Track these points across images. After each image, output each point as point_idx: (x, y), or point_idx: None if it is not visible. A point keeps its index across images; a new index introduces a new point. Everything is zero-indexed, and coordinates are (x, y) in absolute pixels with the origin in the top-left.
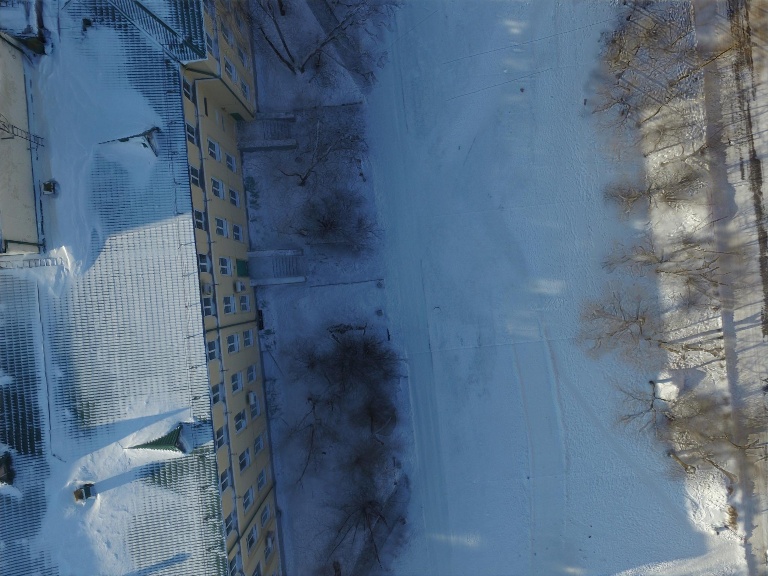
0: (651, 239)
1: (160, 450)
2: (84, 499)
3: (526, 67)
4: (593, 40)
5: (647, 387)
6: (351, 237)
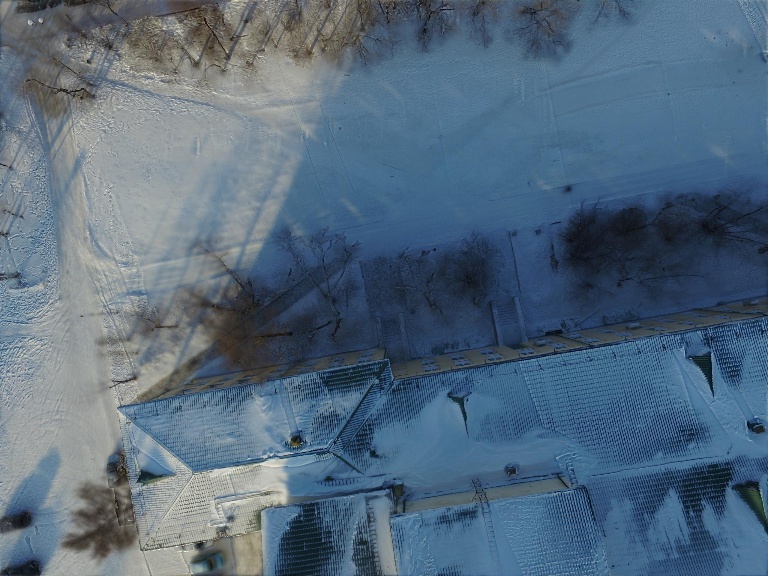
0: (467, 8)
1: (712, 371)
2: (762, 425)
3: (321, 127)
4: (295, 74)
5: (582, 2)
6: (479, 259)
